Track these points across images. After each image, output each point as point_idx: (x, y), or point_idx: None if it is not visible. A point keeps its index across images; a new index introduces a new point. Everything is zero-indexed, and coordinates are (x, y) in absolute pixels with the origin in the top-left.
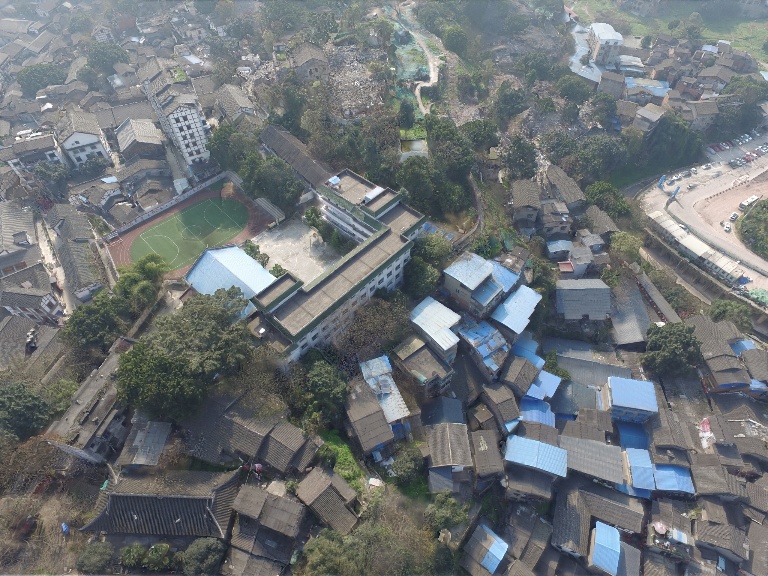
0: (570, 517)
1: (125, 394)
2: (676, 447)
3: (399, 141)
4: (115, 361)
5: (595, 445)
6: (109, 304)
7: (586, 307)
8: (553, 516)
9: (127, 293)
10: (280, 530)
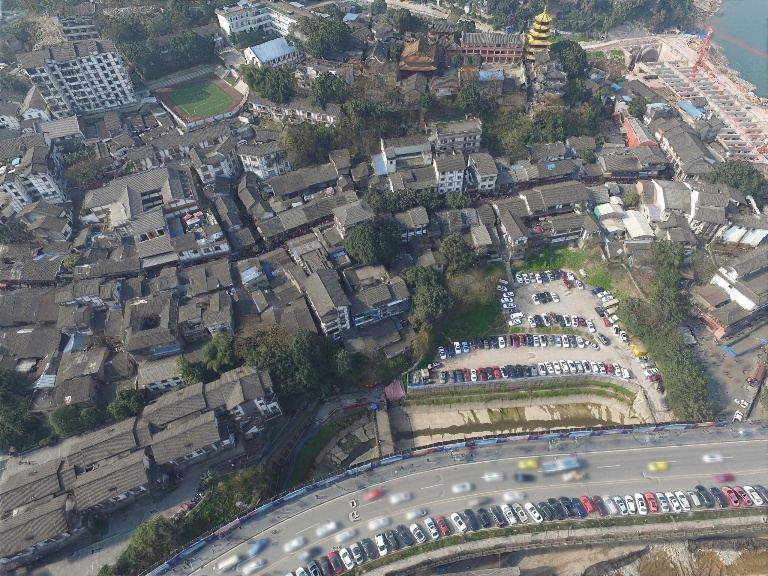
0: None
1: (337, 37)
2: None
3: (192, 8)
4: (310, 65)
5: None
6: (272, 72)
7: None
8: None
9: (264, 74)
10: (391, 29)
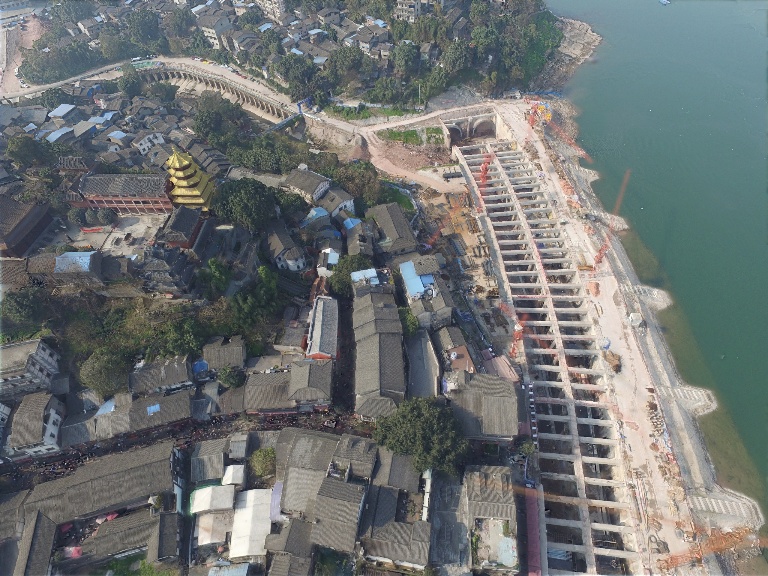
0: (100, 144)
1: None
2: (96, 108)
3: None
4: None
5: (75, 127)
6: None
7: (7, 116)
8: (97, 151)
9: None
10: None
